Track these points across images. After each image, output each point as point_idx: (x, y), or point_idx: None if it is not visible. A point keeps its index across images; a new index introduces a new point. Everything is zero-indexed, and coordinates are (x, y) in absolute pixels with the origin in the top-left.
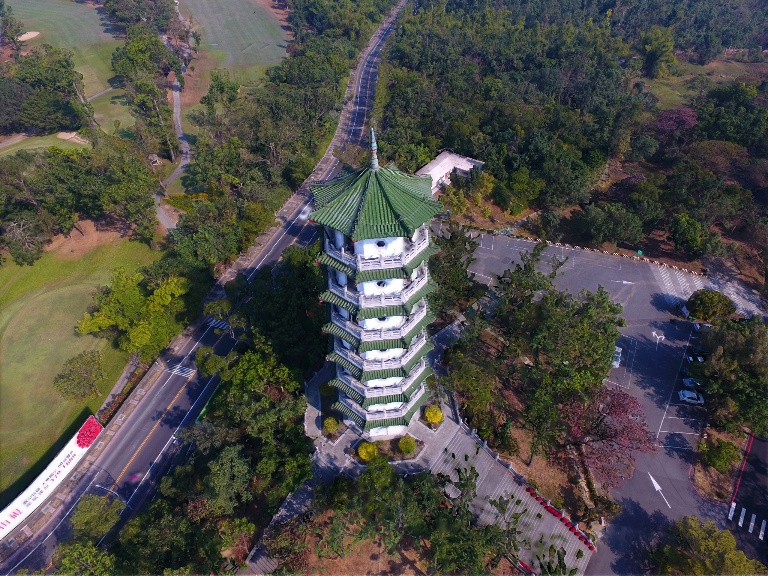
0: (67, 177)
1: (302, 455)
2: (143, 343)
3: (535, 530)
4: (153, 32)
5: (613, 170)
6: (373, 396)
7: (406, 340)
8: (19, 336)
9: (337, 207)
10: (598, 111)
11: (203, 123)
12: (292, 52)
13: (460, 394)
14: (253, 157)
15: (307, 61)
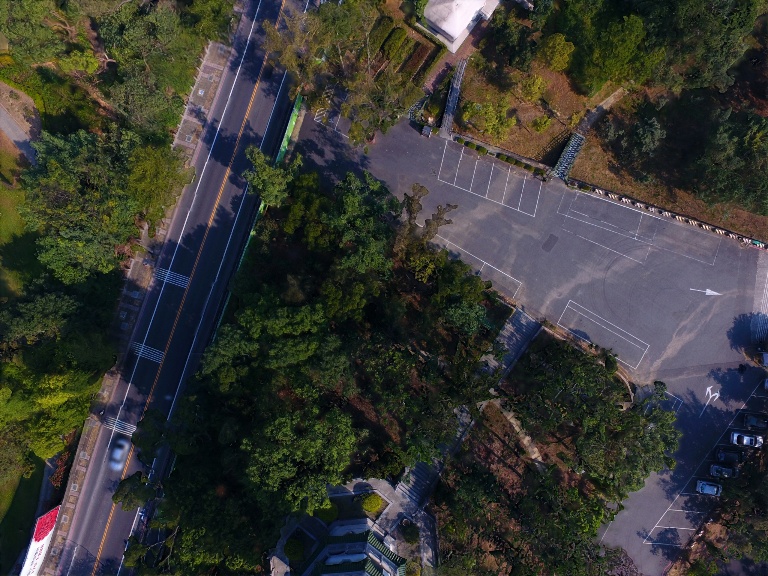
0: None
1: None
2: None
3: None
4: None
5: None
6: None
7: None
8: None
9: None
10: None
11: None
12: None
13: (447, 539)
14: (106, 3)
15: None
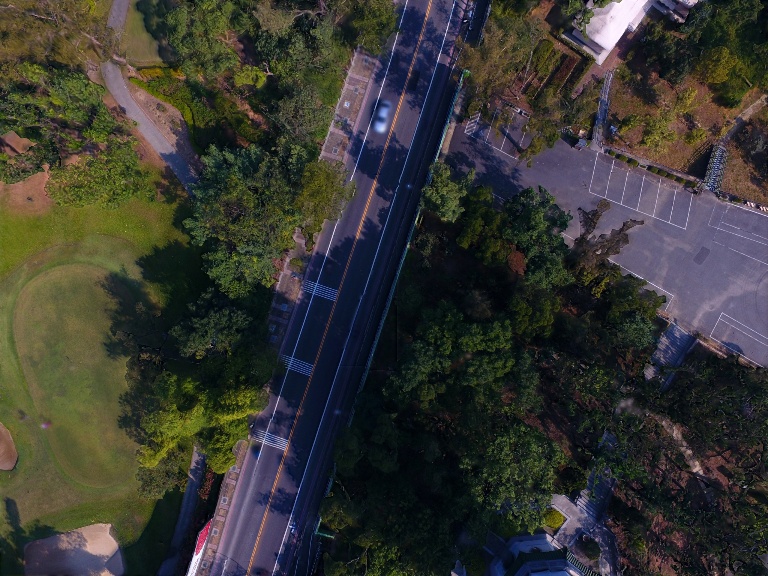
0: None
1: None
2: None
3: None
4: None
5: None
6: None
7: None
8: (39, 355)
9: None
10: None
11: None
12: None
13: (621, 554)
14: (283, 17)
15: None
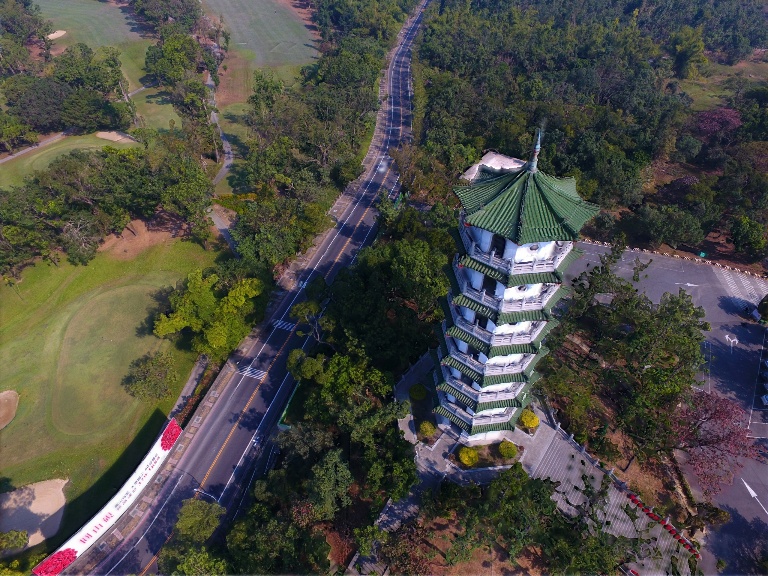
0: (123, 177)
1: (409, 460)
2: (220, 345)
3: None
4: (185, 31)
5: (656, 171)
6: (485, 401)
7: (535, 345)
8: (81, 337)
9: (493, 210)
10: (636, 111)
11: (252, 123)
12: (325, 51)
13: (550, 398)
14: (305, 157)
15: (346, 61)
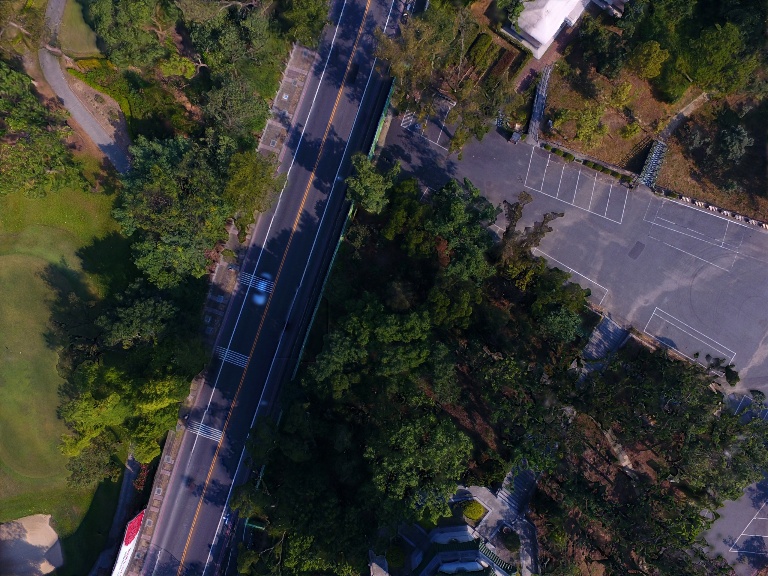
0: None
1: None
2: None
3: None
4: None
5: None
6: None
7: None
8: None
9: None
10: None
11: None
12: None
13: (544, 546)
14: (208, 8)
15: None
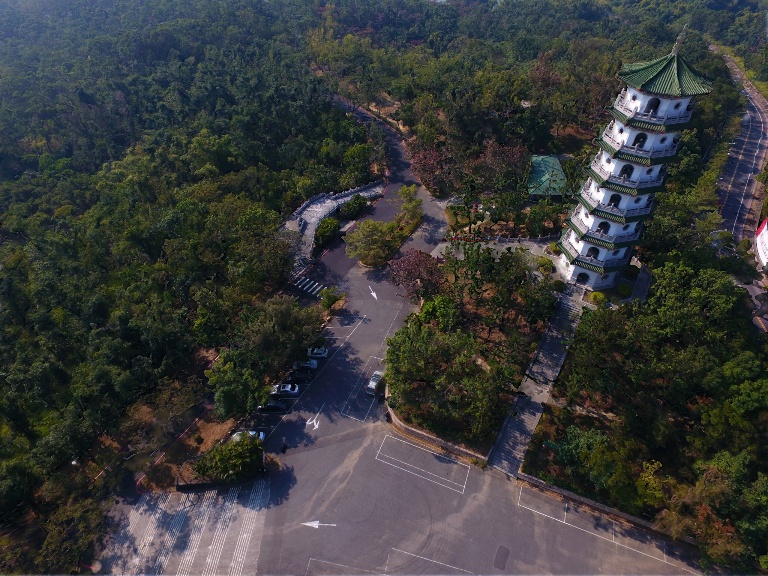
0: None
1: None
2: None
3: (461, 253)
4: None
5: None
6: None
7: None
8: None
9: None
10: None
11: None
12: None
13: None
14: None
15: None
